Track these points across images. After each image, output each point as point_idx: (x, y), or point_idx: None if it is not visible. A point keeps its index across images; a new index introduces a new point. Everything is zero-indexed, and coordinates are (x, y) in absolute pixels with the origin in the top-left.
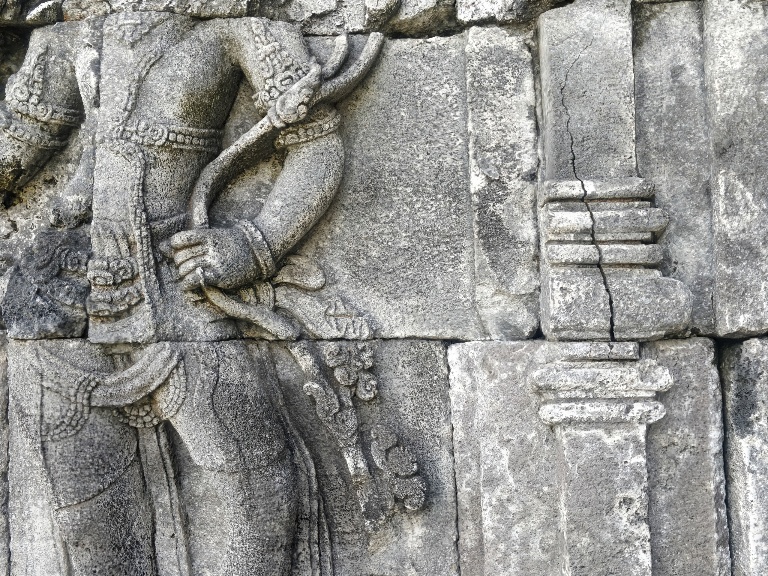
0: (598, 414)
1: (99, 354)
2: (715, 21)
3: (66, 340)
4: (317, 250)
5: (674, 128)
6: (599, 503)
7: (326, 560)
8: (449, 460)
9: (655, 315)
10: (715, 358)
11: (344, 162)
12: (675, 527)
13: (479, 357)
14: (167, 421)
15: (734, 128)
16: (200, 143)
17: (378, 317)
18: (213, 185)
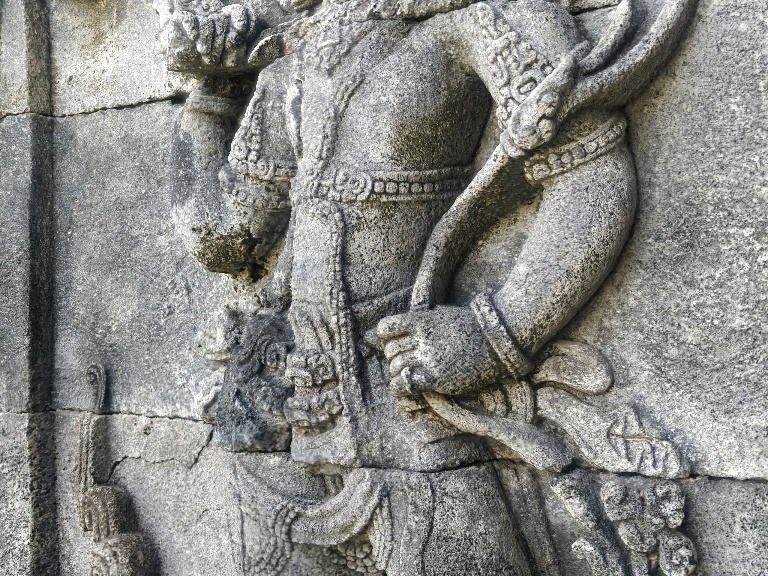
0: None
1: (305, 474)
2: None
3: (267, 454)
4: (601, 332)
5: None
6: None
7: None
8: None
9: None
10: None
11: (628, 197)
12: None
13: None
14: None
15: None
16: (425, 189)
17: (698, 441)
18: (450, 244)
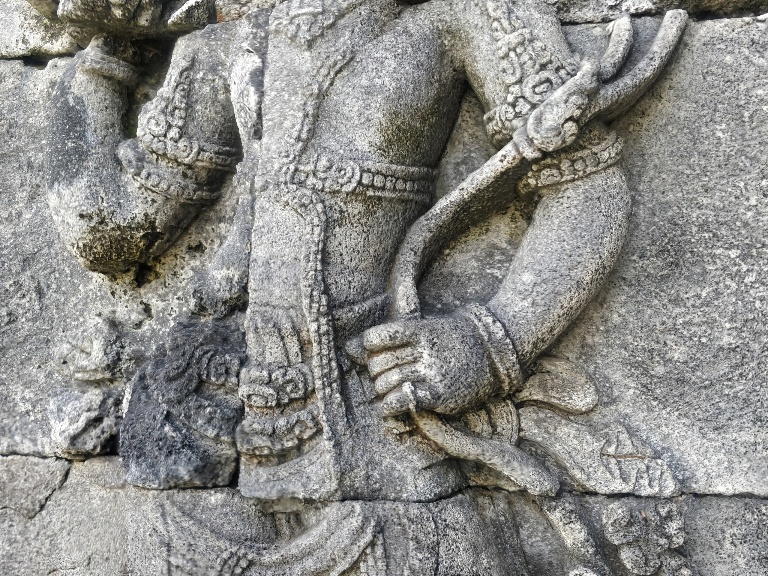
0: None
1: (254, 513)
2: None
3: (206, 491)
4: (583, 349)
5: None
6: None
7: None
8: None
9: None
10: None
11: (631, 211)
12: None
13: None
14: None
15: None
16: (407, 187)
17: (686, 459)
18: (424, 250)
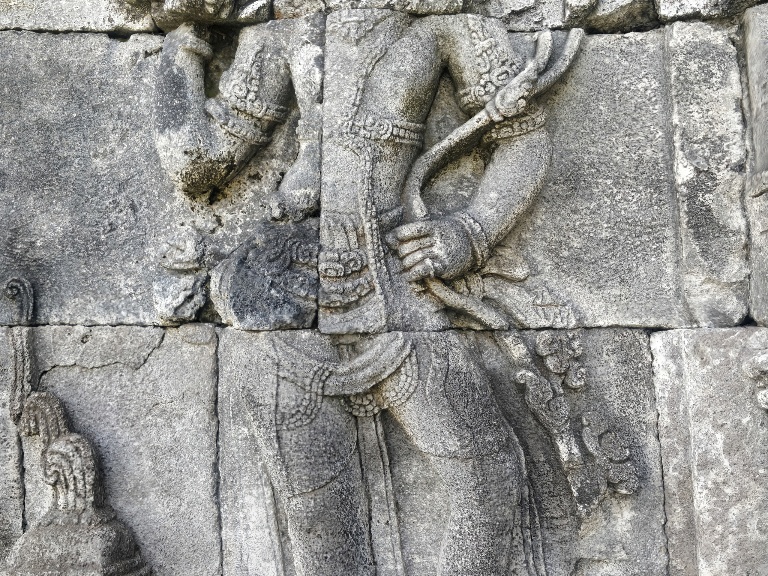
0: None
1: (328, 344)
2: None
3: (299, 331)
4: (520, 242)
5: None
6: None
7: (538, 545)
8: (656, 445)
9: None
10: None
11: None
12: None
13: (690, 344)
14: (383, 410)
15: None
16: (415, 137)
17: (581, 306)
18: (423, 179)
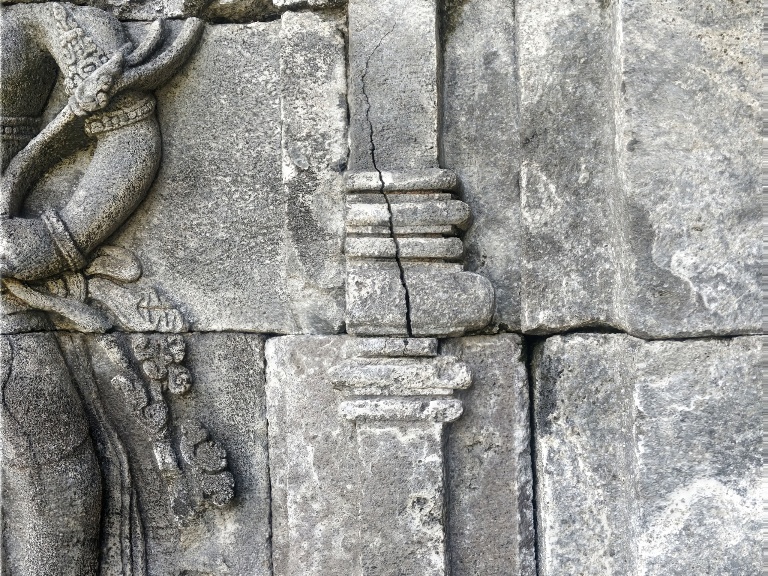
0: (392, 412)
1: None
2: (520, 6)
3: None
4: (134, 241)
5: (486, 117)
6: (392, 503)
7: (137, 555)
8: (263, 456)
9: (452, 311)
10: (523, 355)
11: (155, 151)
12: (478, 528)
13: (287, 352)
14: None
15: (538, 117)
16: (6, 131)
17: (195, 309)
18: (24, 174)
